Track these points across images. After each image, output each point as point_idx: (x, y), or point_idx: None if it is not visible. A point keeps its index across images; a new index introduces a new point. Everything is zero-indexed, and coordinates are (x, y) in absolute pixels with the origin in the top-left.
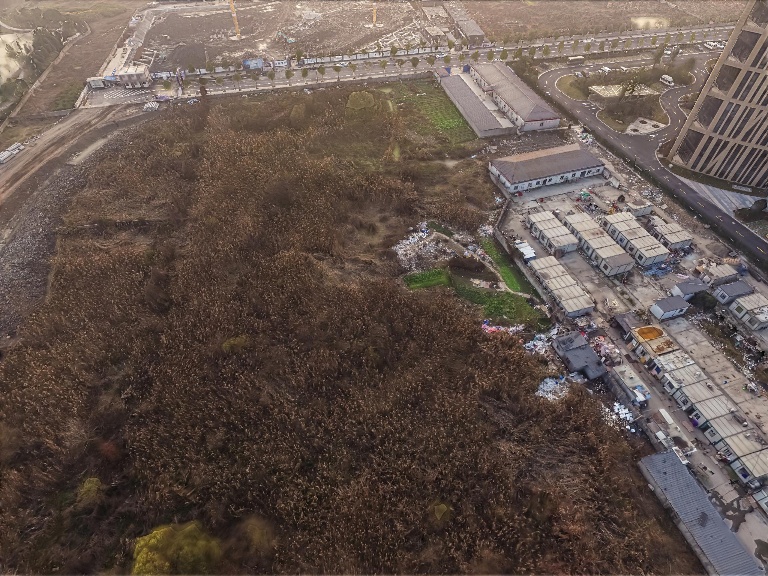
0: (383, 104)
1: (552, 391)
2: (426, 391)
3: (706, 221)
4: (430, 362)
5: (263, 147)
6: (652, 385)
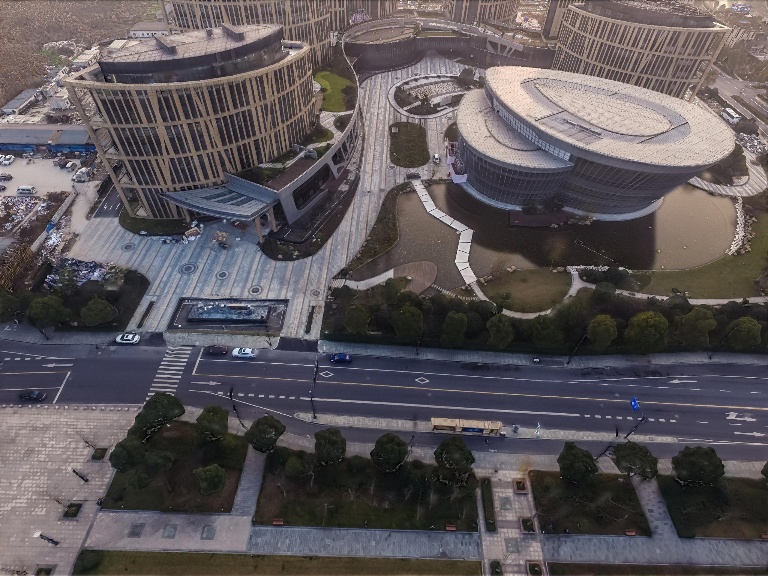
0: (136, 2)
1: None
2: None
3: None
4: None
5: (41, 6)
6: None
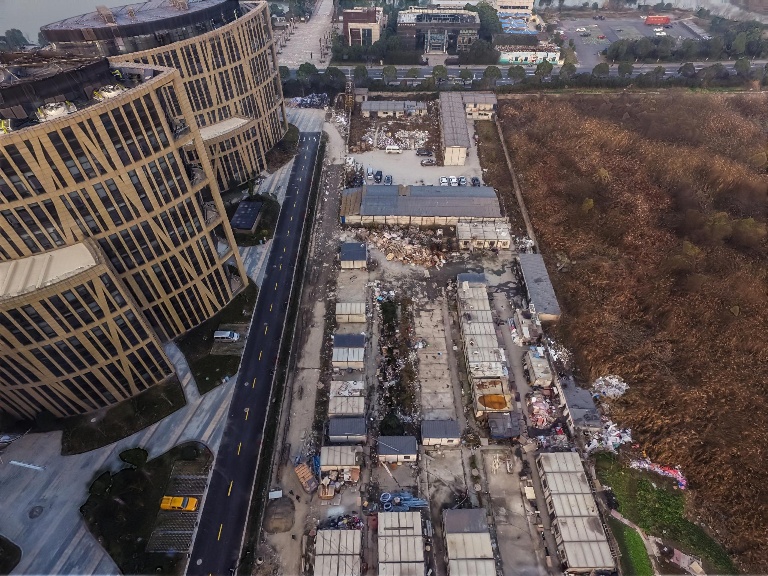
0: None
1: (611, 387)
2: (761, 400)
3: (248, 575)
4: (763, 431)
5: None
6: (509, 368)
